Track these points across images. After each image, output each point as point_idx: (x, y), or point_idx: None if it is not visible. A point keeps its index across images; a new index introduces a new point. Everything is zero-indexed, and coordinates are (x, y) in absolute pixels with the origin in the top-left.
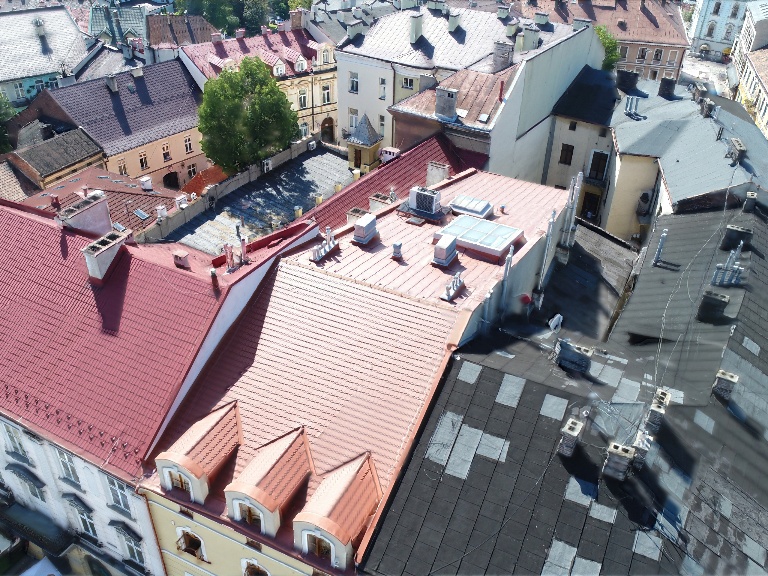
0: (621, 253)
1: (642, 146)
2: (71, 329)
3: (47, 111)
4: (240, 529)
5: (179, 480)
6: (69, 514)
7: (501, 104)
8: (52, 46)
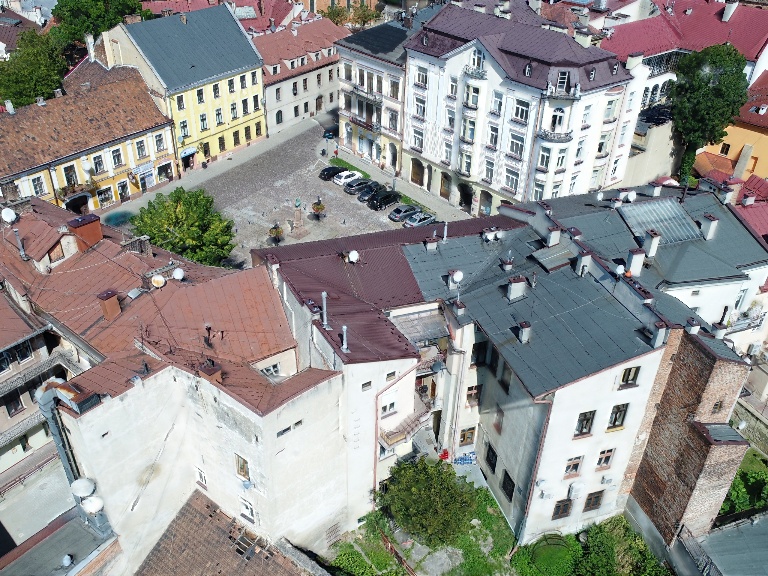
0: None
1: None
2: None
3: None
4: None
5: None
6: None
7: None
8: None
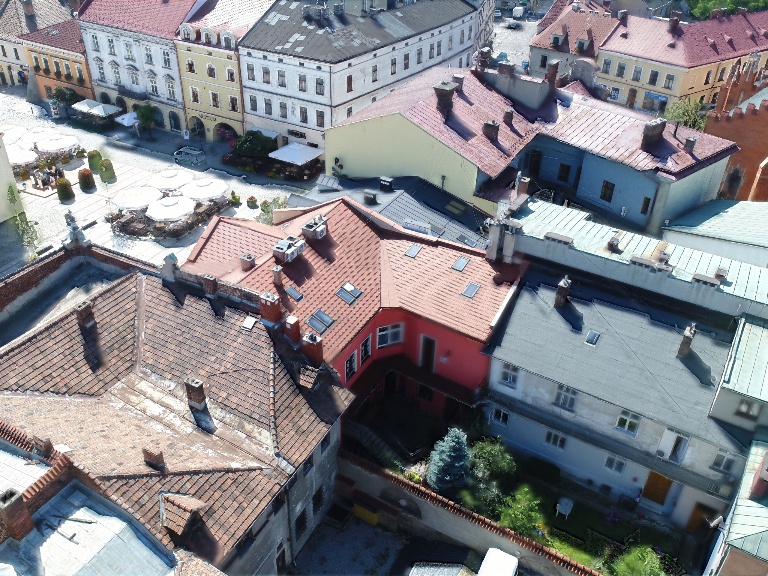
0: None
1: None
2: (151, 5)
3: None
4: (205, 45)
5: (187, 34)
6: (147, 85)
7: None
8: None
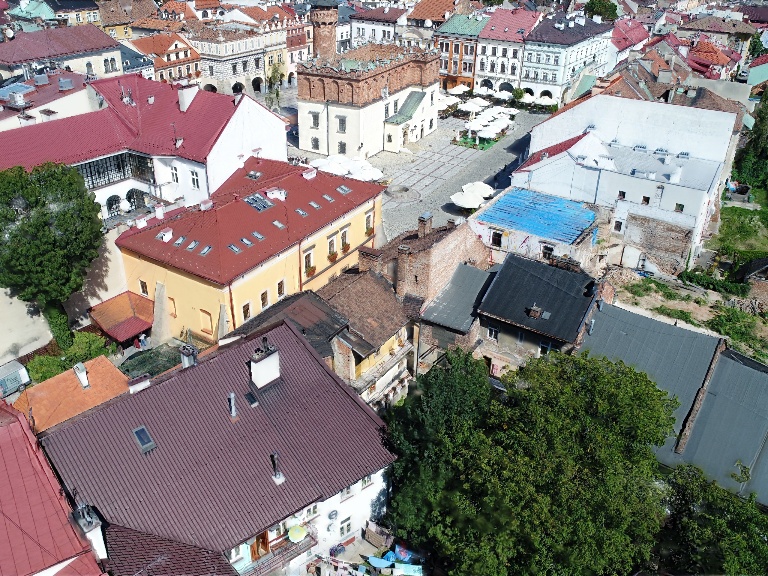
0: None
1: None
2: None
3: None
4: None
5: None
6: None
7: None
8: None
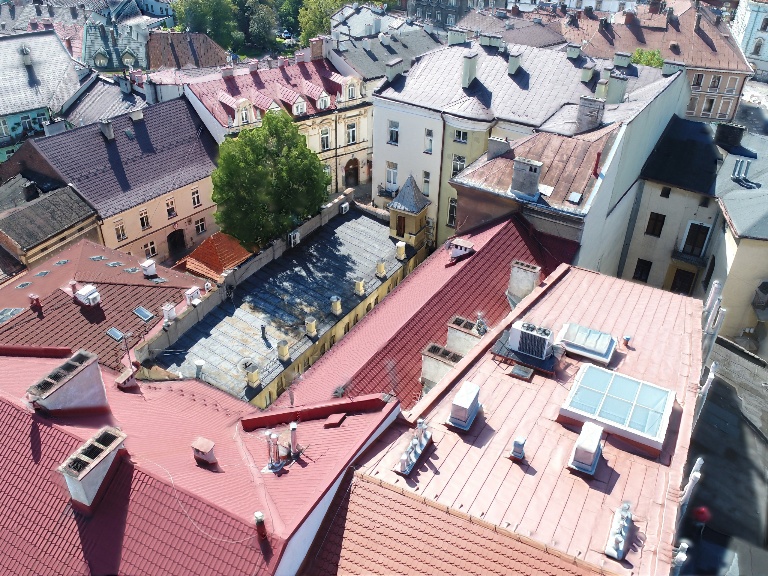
0: (756, 374)
1: (766, 227)
2: None
3: (31, 164)
4: None
5: None
6: None
7: (597, 180)
8: (40, 77)
